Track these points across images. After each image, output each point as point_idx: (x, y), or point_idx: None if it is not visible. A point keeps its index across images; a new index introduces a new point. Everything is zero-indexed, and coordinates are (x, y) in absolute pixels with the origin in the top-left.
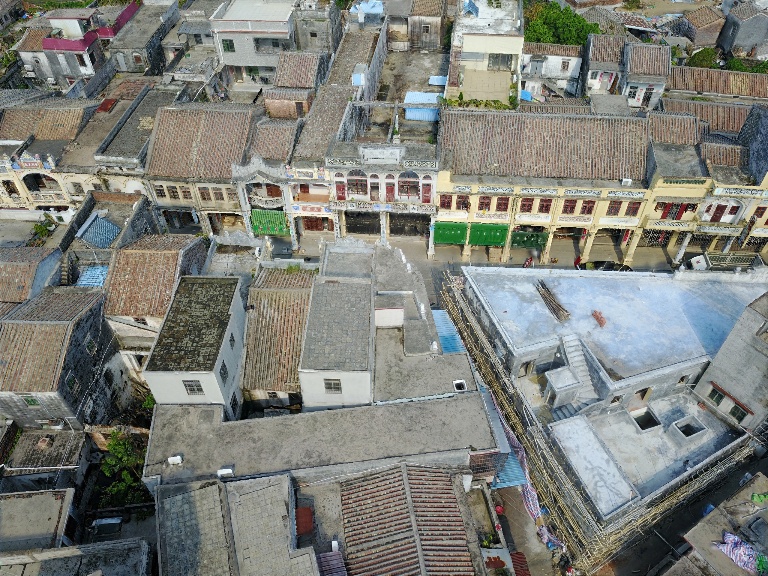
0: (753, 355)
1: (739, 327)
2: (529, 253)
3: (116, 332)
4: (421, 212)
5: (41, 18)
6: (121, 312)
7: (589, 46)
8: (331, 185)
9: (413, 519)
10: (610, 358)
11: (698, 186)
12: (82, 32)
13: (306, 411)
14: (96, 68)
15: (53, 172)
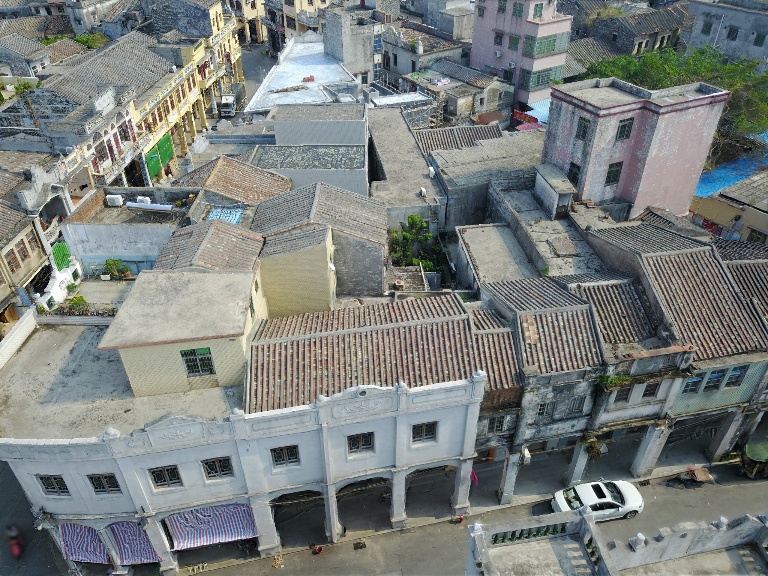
0: (355, 39)
1: (344, 31)
2: None
3: None
4: (145, 145)
5: None
6: None
7: None
8: (89, 163)
9: (447, 128)
10: (338, 81)
11: (202, 47)
12: None
13: None
14: None
15: None
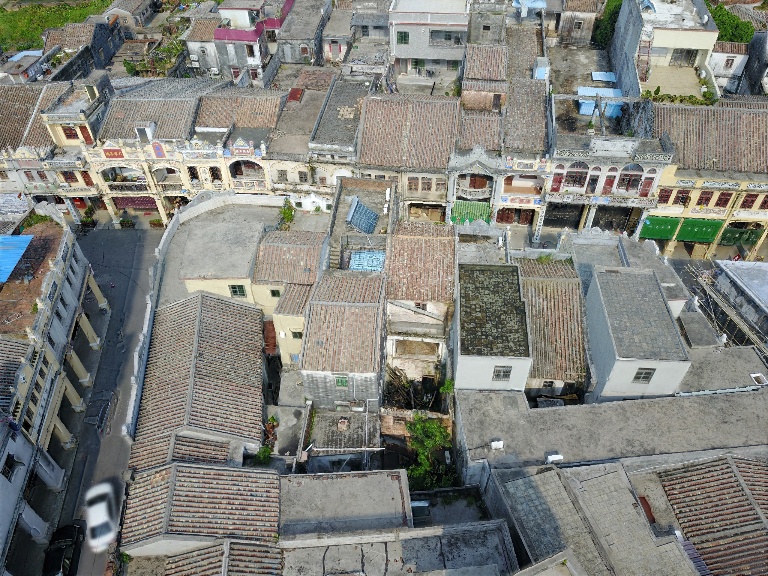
0: None
1: None
2: (730, 250)
3: (389, 317)
4: (640, 206)
5: (197, 9)
6: (405, 297)
7: (761, 43)
8: (549, 177)
9: (760, 511)
10: None
11: None
12: (250, 23)
13: (599, 400)
14: (262, 59)
15: (264, 159)
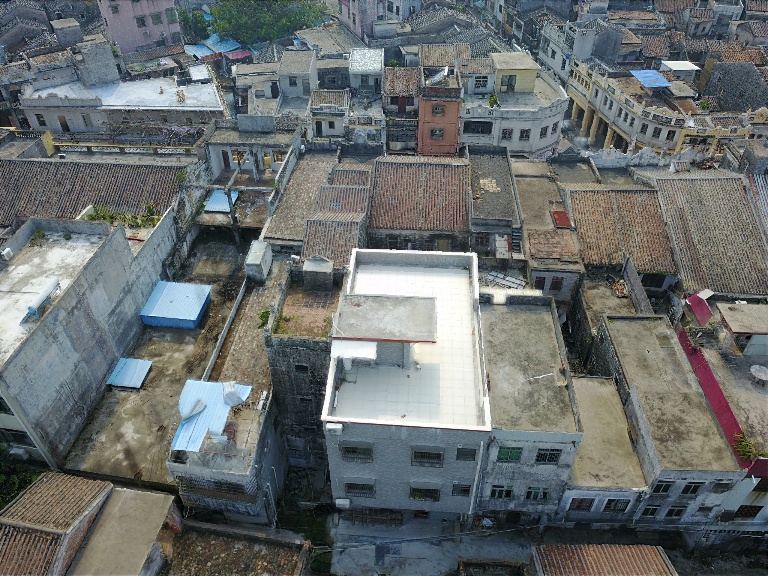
0: None
1: None
2: None
3: None
4: None
5: None
6: None
7: None
8: None
9: None
10: None
11: None
12: None
13: None
14: None
15: None
